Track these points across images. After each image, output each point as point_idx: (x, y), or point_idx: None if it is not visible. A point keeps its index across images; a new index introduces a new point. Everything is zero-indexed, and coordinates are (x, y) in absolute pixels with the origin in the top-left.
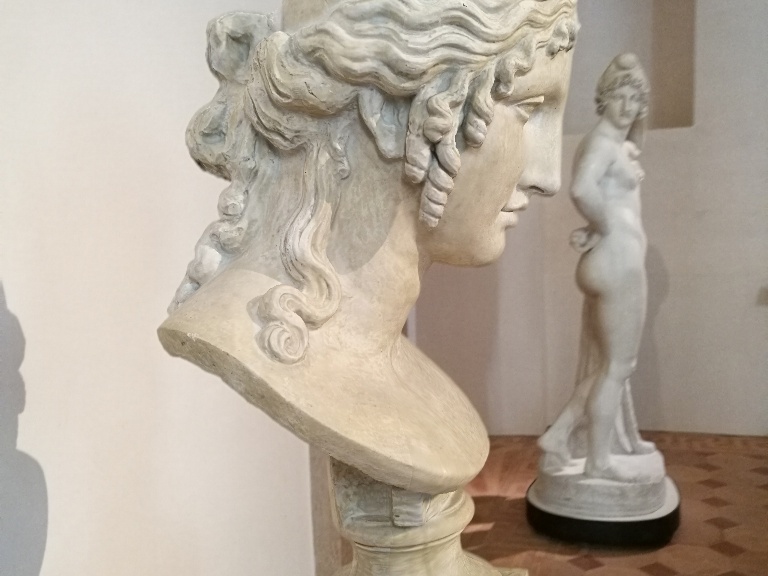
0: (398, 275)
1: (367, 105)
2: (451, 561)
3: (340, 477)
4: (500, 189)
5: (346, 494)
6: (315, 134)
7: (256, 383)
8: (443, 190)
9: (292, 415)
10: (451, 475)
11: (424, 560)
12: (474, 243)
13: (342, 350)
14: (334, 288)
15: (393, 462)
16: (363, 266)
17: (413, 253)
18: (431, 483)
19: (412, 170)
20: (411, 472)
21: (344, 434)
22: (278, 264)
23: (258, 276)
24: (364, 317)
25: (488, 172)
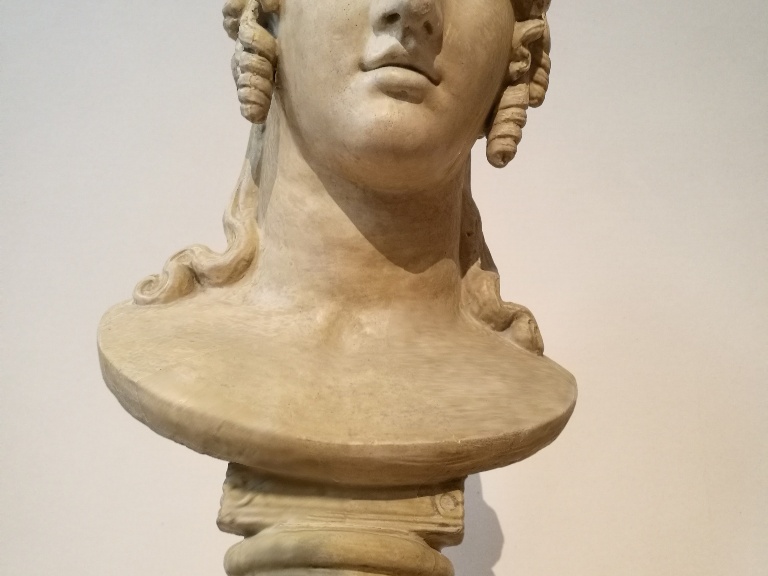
0: (297, 207)
1: None
2: None
3: None
4: (324, 40)
5: None
6: None
7: None
8: (245, 71)
9: None
10: (190, 407)
11: None
12: (332, 124)
13: (239, 306)
14: (237, 239)
15: None
16: None
17: (309, 175)
18: (164, 415)
19: None
20: None
21: (103, 348)
22: None
23: None
24: (276, 269)
25: (299, 28)
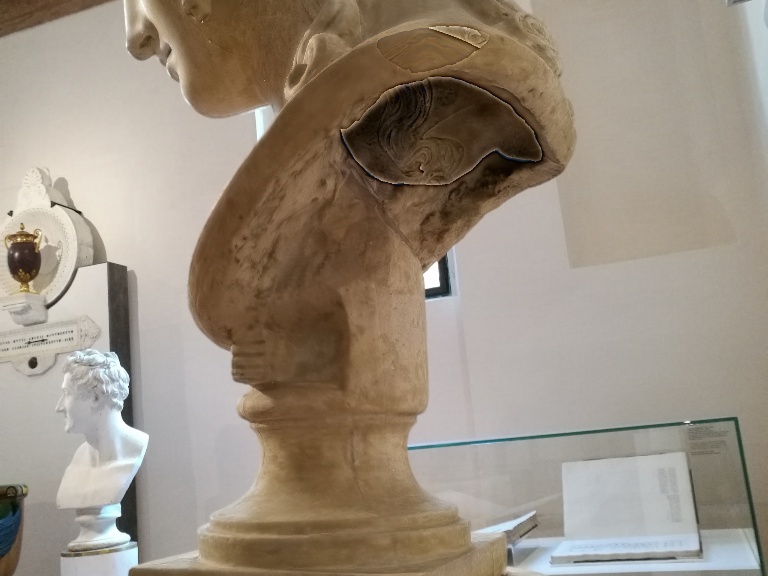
0: None
1: None
2: None
3: None
4: None
5: None
6: None
7: None
8: None
9: None
10: None
11: None
12: None
13: None
14: (384, 139)
15: None
16: None
17: None
18: None
19: None
20: None
21: None
22: (436, 105)
23: (456, 116)
24: None
25: None
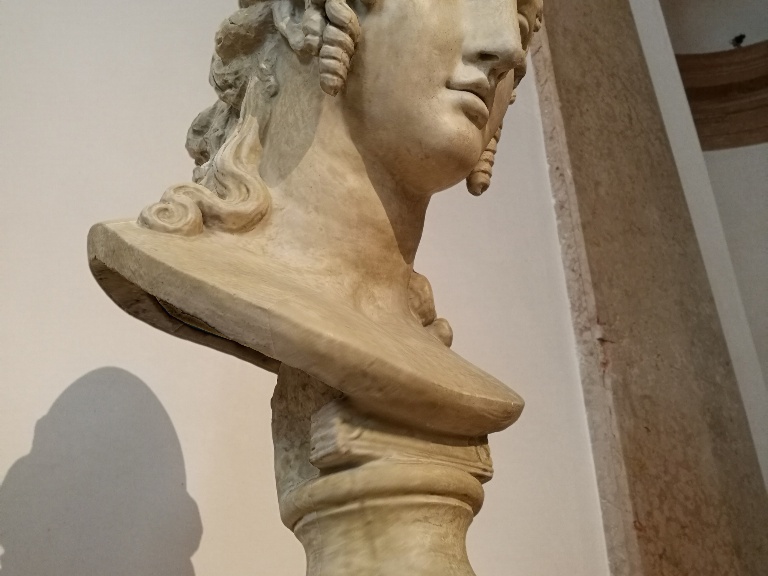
0: (336, 180)
1: (277, 13)
2: (417, 547)
3: (280, 437)
4: (424, 50)
5: (286, 459)
6: (250, 69)
7: (110, 239)
8: (335, 45)
9: (133, 259)
10: (342, 341)
11: (367, 534)
12: (413, 122)
13: (262, 256)
14: (254, 191)
15: (239, 302)
16: (292, 172)
17: (353, 155)
18: (306, 345)
19: (306, 39)
20: (267, 319)
21: (180, 269)
22: (216, 194)
23: None
24: (300, 230)
25: (399, 30)
